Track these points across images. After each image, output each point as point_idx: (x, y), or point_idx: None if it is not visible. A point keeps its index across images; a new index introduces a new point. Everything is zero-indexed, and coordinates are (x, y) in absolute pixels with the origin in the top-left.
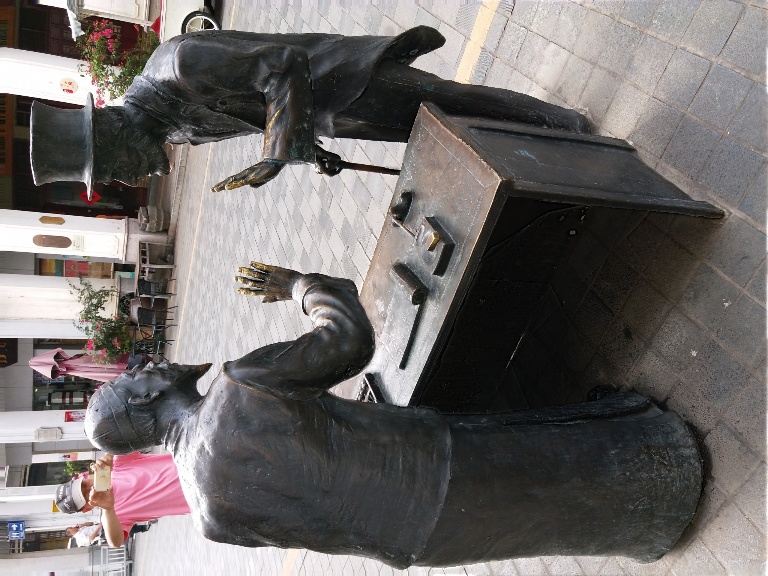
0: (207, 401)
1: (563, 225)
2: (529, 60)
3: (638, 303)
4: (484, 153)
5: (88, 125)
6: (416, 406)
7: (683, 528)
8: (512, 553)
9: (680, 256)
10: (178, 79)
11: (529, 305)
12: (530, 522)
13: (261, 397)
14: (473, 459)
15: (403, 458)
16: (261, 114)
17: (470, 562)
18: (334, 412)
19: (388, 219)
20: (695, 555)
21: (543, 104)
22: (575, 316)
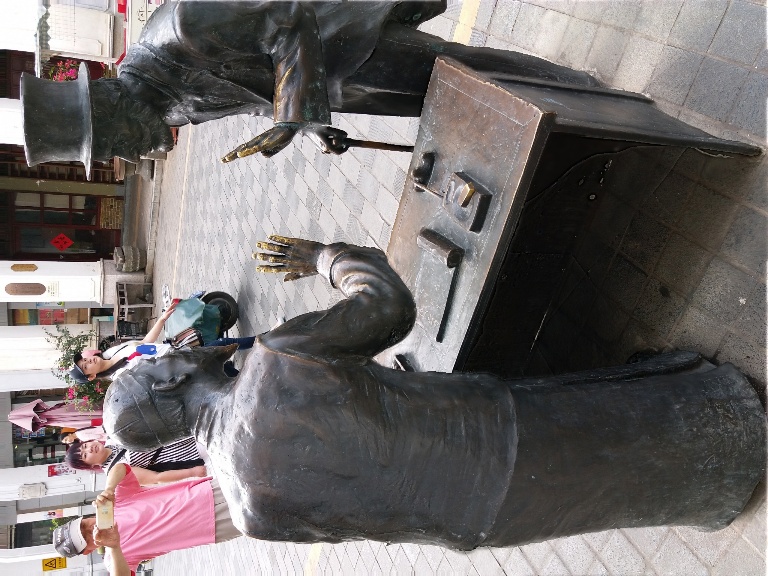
0: (243, 377)
1: (583, 189)
2: (526, 31)
3: (673, 259)
4: None
5: (84, 94)
6: None
7: (753, 487)
8: (582, 527)
9: (716, 202)
10: (180, 39)
11: (551, 279)
12: (601, 488)
13: (305, 365)
14: (539, 420)
15: (465, 422)
16: (266, 82)
17: (540, 539)
18: (384, 379)
19: (407, 188)
20: None
21: (552, 65)
22: (603, 283)
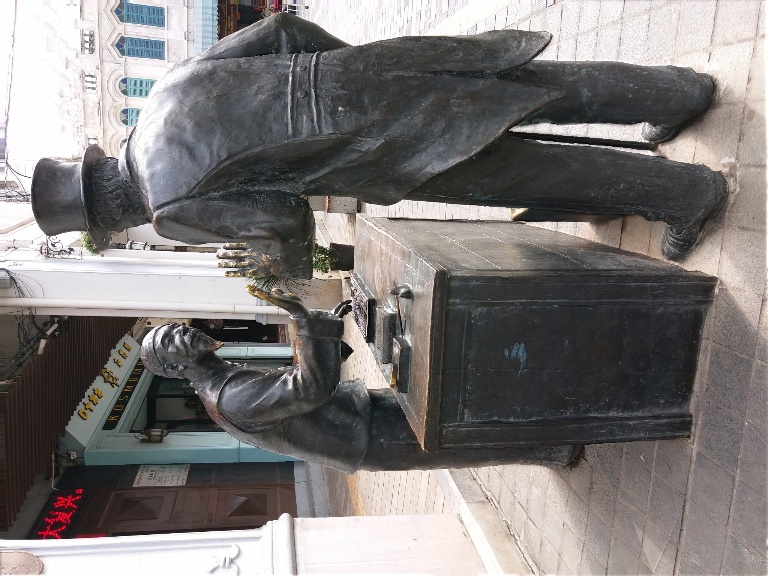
0: (209, 404)
1: None
2: None
3: None
4: (436, 404)
5: None
6: None
7: None
8: None
9: None
10: None
11: None
12: None
13: None
14: None
15: None
16: None
17: None
18: (289, 432)
19: None
20: (544, 467)
21: (661, 194)
22: None
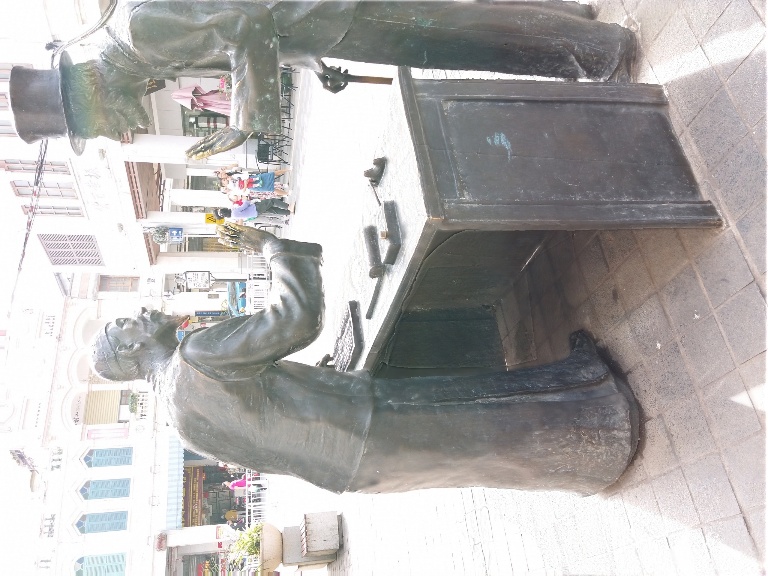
0: (169, 368)
1: None
2: None
3: (630, 272)
4: (428, 169)
5: None
6: (378, 351)
7: (606, 486)
8: (437, 487)
9: (674, 245)
10: (135, 51)
11: None
12: None
13: (205, 378)
14: (389, 439)
15: (324, 434)
16: None
17: None
18: (271, 389)
19: None
20: (614, 505)
21: (577, 26)
22: (580, 254)
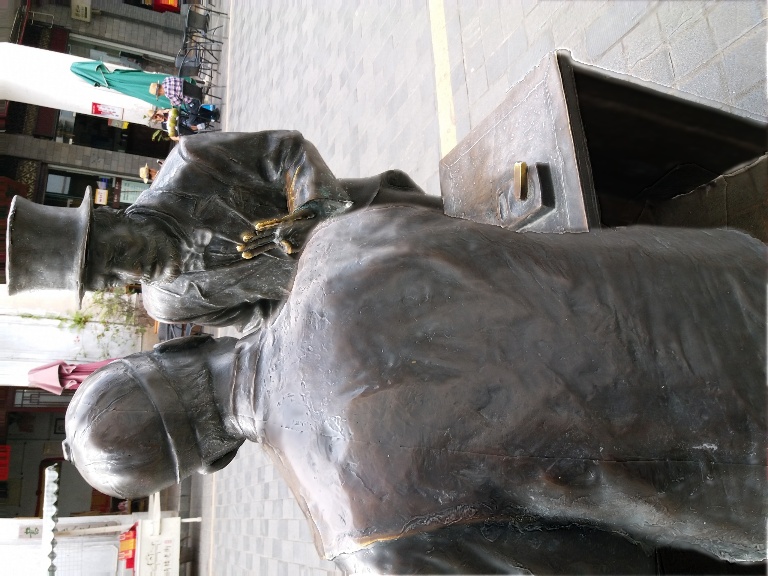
0: (297, 275)
1: None
2: None
3: None
4: None
5: (84, 205)
6: None
7: None
8: None
9: None
10: (185, 158)
11: None
12: None
13: (385, 214)
14: None
15: (661, 239)
16: None
17: None
18: None
19: None
20: None
21: None
22: None
